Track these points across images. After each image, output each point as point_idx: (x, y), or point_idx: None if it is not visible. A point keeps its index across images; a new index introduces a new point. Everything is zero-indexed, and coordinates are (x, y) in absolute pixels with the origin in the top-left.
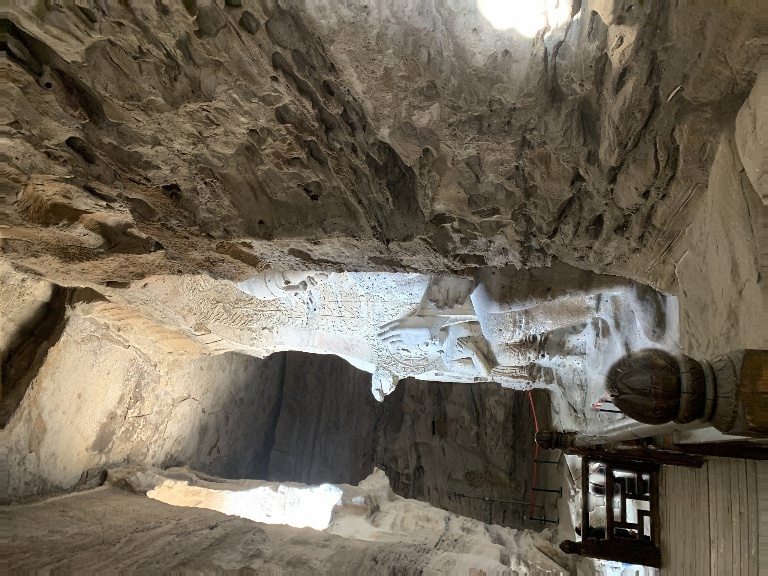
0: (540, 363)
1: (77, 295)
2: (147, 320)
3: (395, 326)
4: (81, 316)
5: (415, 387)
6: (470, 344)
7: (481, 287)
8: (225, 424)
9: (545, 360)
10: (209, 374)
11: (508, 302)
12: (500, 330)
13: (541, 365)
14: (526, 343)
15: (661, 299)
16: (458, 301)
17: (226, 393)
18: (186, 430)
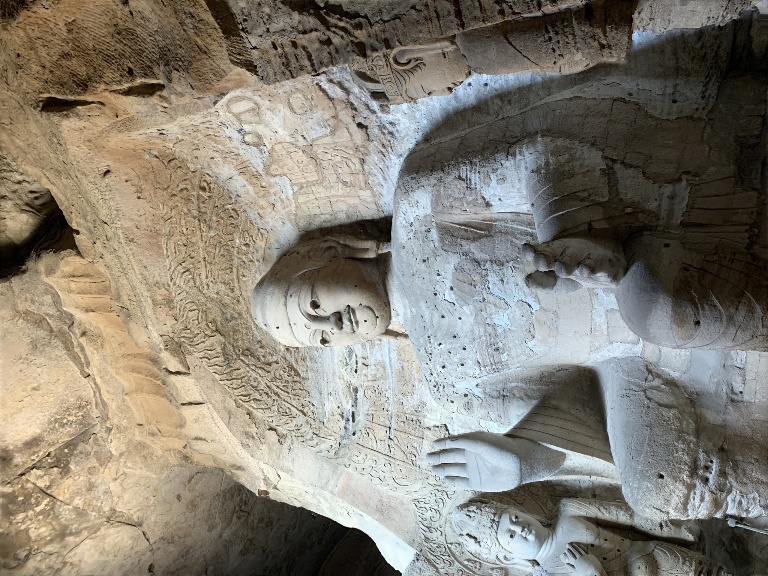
0: None
1: (52, 243)
2: (124, 337)
3: None
4: (42, 276)
5: None
6: (592, 556)
7: (636, 269)
8: None
9: None
10: (186, 516)
11: (694, 301)
12: (660, 476)
13: None
14: None
15: None
16: (583, 262)
17: (198, 567)
18: (107, 575)
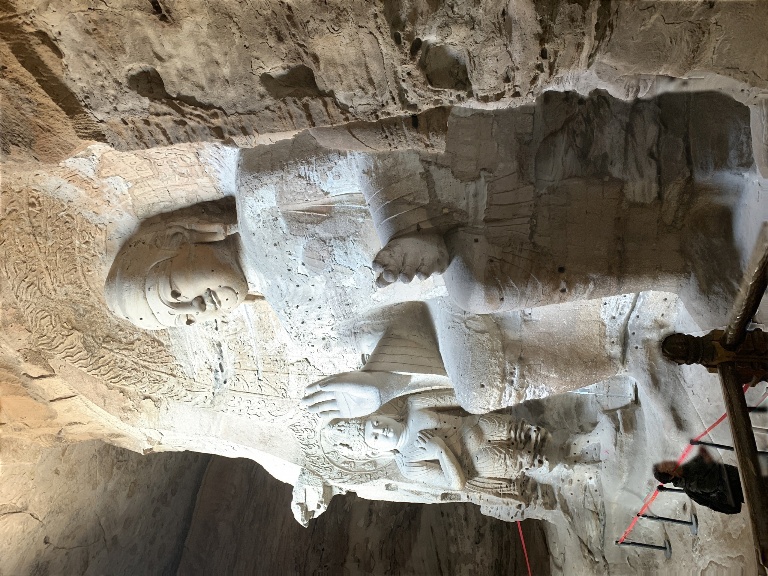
0: (536, 477)
1: None
2: None
3: (328, 380)
4: None
5: (362, 546)
6: (437, 438)
7: (456, 262)
8: (80, 572)
9: (543, 470)
10: (68, 484)
11: (498, 285)
12: (482, 386)
13: (537, 480)
14: (516, 443)
15: (740, 287)
16: (420, 269)
17: (91, 522)
18: (6, 563)
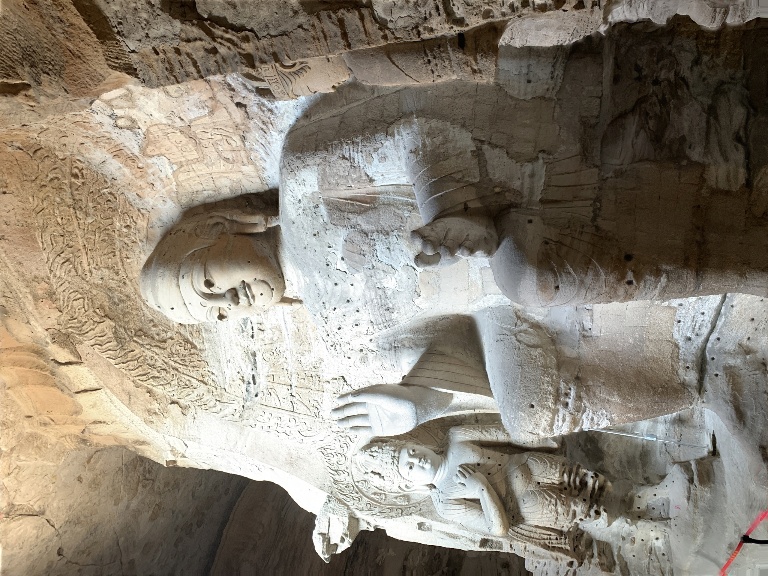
0: (591, 531)
1: None
2: None
3: (361, 390)
4: None
5: None
6: (479, 474)
7: (506, 244)
8: None
9: (600, 523)
10: (90, 495)
11: (553, 270)
12: (531, 406)
13: (593, 536)
14: (569, 488)
15: None
16: (463, 244)
17: (109, 540)
18: (15, 569)
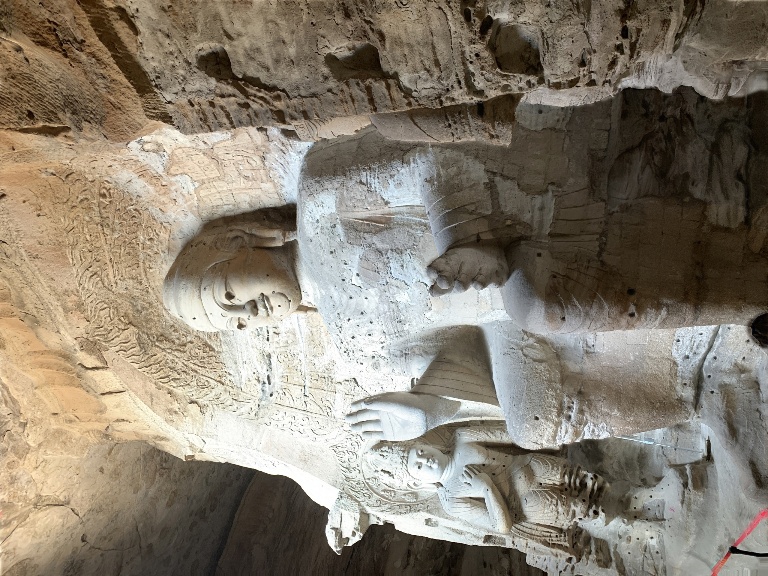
0: (589, 529)
1: None
2: (28, 336)
3: (374, 398)
4: None
5: None
6: (484, 474)
7: (516, 276)
8: (113, 575)
9: (598, 522)
10: (111, 485)
11: (560, 303)
12: (536, 418)
13: (591, 534)
14: (570, 489)
15: None
16: (476, 278)
17: (129, 526)
18: (43, 555)
